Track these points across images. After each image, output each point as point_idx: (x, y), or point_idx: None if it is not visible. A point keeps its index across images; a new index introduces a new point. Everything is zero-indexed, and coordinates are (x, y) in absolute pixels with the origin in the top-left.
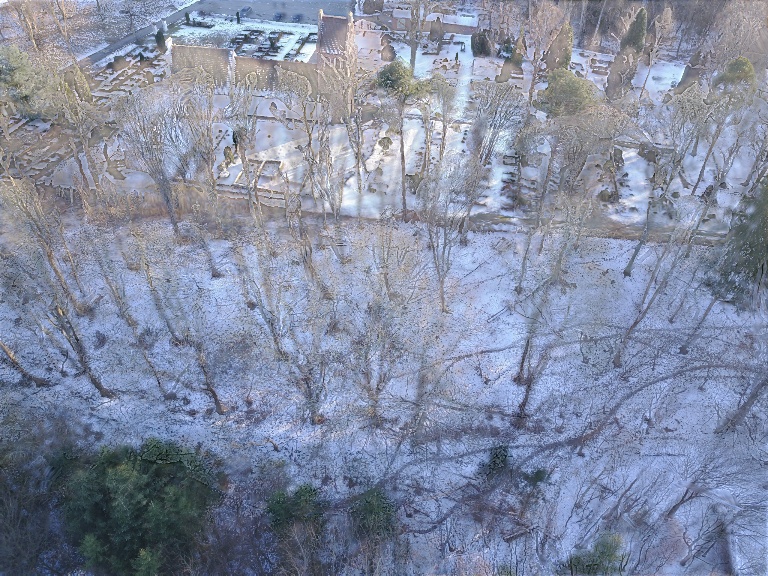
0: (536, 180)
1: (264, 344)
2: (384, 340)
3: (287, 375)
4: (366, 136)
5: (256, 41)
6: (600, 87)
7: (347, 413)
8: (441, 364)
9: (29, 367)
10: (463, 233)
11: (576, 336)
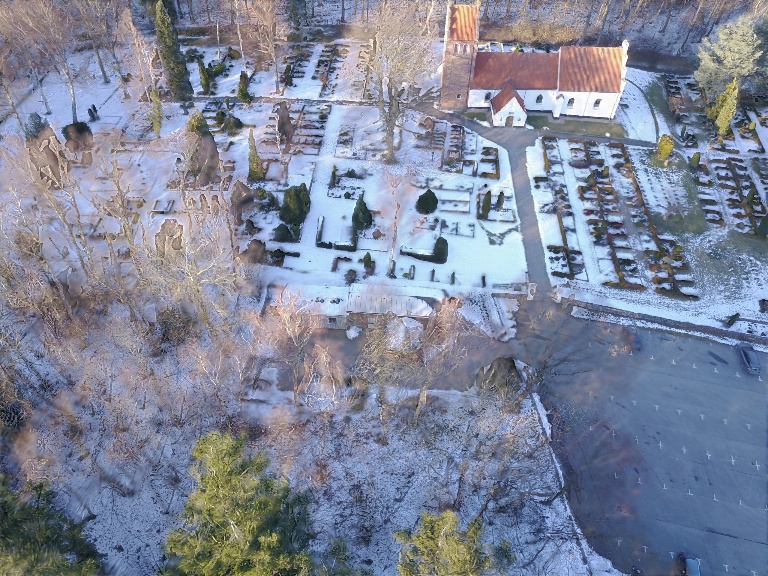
0: (282, 65)
1: (440, 7)
2: (383, 1)
3: (426, 5)
4: (421, 81)
5: (647, 259)
6: (157, 169)
7: (396, 0)
8: (356, 8)
9: (542, 6)
10: (344, 11)
11: (288, 14)
